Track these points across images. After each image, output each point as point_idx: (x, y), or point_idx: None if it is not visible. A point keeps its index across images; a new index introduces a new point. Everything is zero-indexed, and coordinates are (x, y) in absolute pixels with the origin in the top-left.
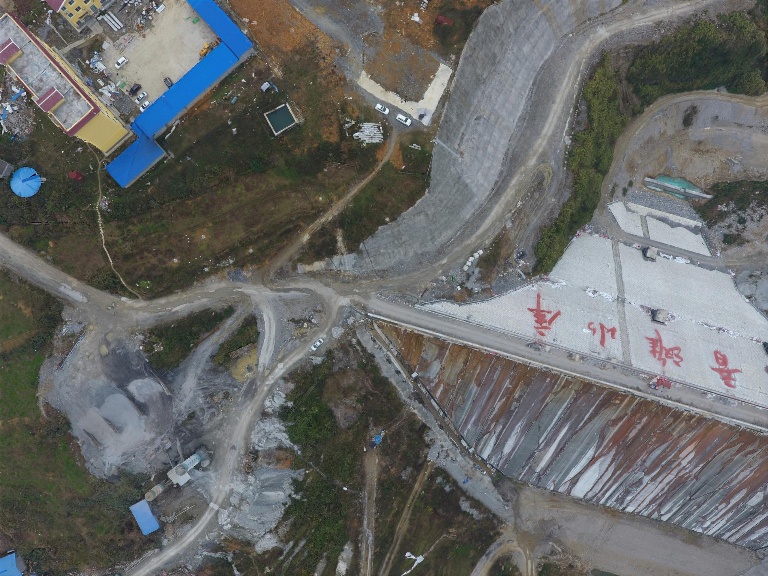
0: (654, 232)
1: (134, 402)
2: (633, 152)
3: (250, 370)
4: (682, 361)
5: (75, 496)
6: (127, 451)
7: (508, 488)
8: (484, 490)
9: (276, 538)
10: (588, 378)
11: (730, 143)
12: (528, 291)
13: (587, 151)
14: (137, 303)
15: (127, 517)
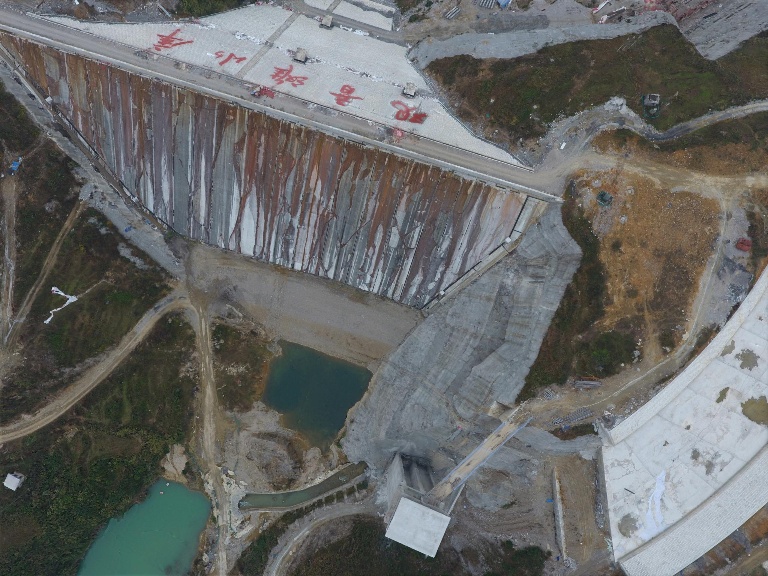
0: (341, 10)
1: None
2: None
3: None
4: (301, 85)
5: None
6: None
7: (180, 245)
8: (151, 242)
9: None
10: (190, 84)
11: None
12: (169, 26)
13: None
14: None
15: None
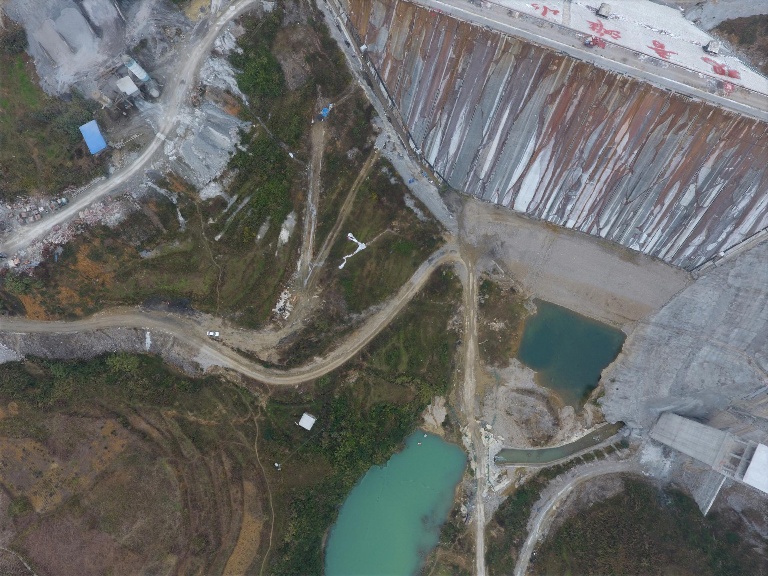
0: None
1: (89, 23)
2: None
3: (203, 11)
4: (620, 38)
5: (28, 112)
6: (80, 71)
7: (454, 199)
8: (429, 195)
9: (221, 187)
10: (526, 32)
11: None
12: None
13: None
14: None
15: (77, 145)
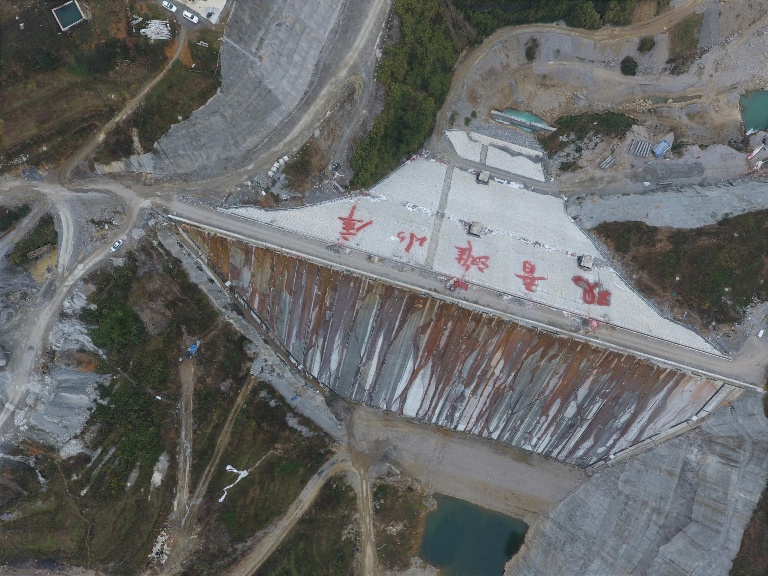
0: (492, 159)
1: None
2: (473, 82)
3: (49, 271)
4: (487, 268)
5: None
6: None
7: (341, 407)
8: (315, 408)
9: (82, 444)
10: (385, 279)
11: (574, 78)
12: (344, 203)
13: (399, 65)
14: None
15: None
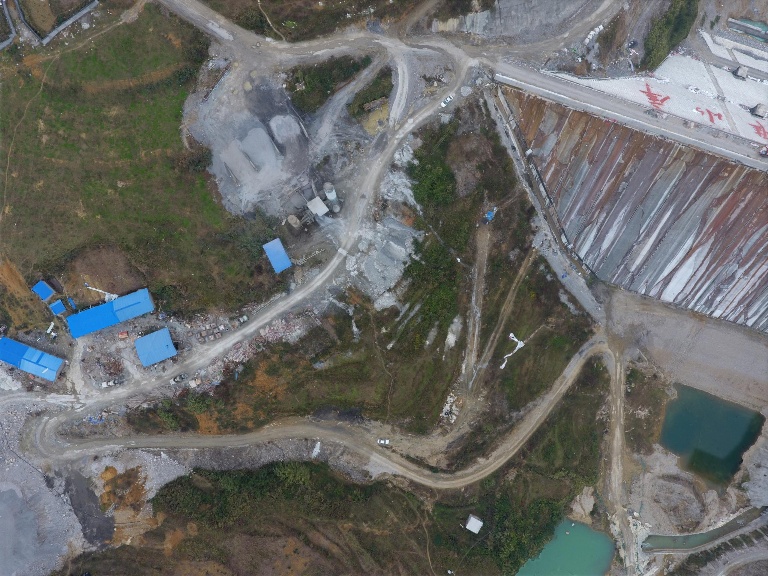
0: (741, 59)
1: (273, 141)
2: None
3: (381, 124)
4: None
5: (211, 231)
6: (264, 189)
7: (601, 290)
8: (580, 288)
9: (395, 297)
10: (703, 143)
11: None
12: (637, 80)
13: None
14: (281, 44)
15: (256, 261)
